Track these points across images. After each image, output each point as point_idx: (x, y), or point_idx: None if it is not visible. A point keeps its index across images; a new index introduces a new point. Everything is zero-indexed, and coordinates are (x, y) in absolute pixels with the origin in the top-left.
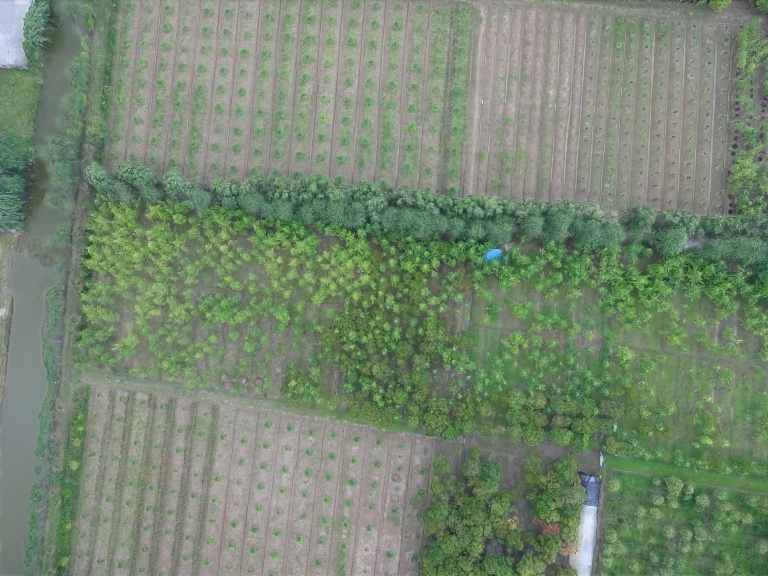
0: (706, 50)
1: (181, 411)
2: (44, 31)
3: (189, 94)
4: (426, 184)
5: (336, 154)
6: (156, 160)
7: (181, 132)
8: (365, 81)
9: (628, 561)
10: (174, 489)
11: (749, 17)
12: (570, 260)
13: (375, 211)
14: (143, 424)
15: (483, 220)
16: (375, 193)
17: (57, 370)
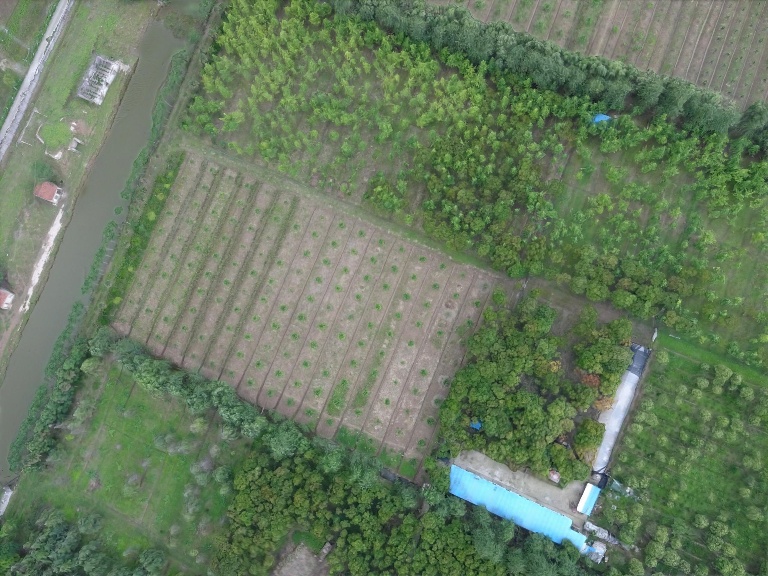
0: None
1: (264, 195)
2: None
3: None
4: None
5: None
6: None
7: None
8: None
9: (656, 438)
10: (237, 263)
11: None
12: (677, 137)
13: (503, 46)
14: (225, 198)
15: (604, 78)
16: (507, 32)
17: (160, 131)
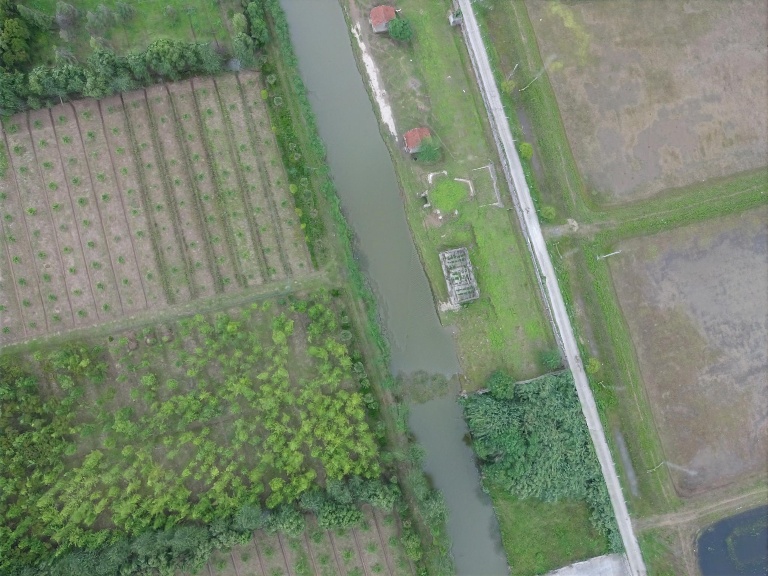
0: None
1: (207, 284)
2: None
3: None
4: None
5: None
6: None
7: (323, 574)
8: None
9: None
10: (183, 206)
11: None
12: None
13: None
14: None
15: None
16: None
17: None
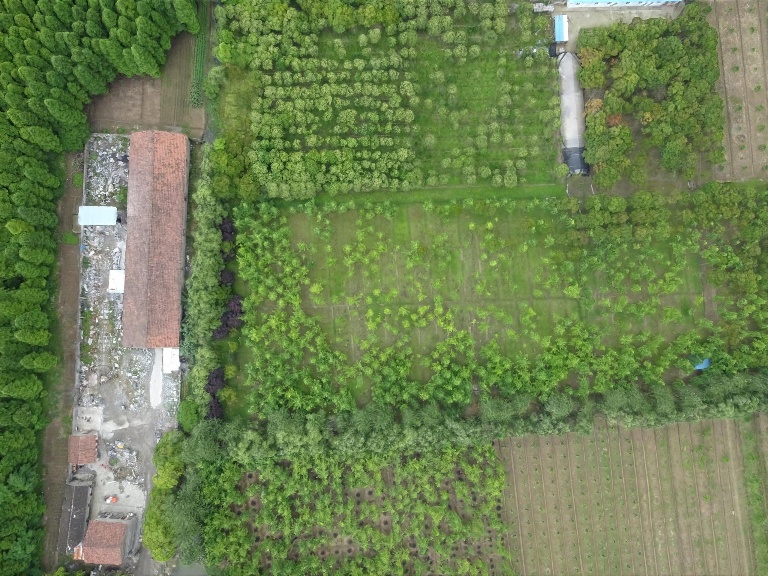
0: None
1: None
2: None
3: None
4: None
5: None
6: None
7: None
8: None
9: None
10: None
11: None
12: (641, 370)
13: None
14: None
15: (733, 394)
16: None
17: None
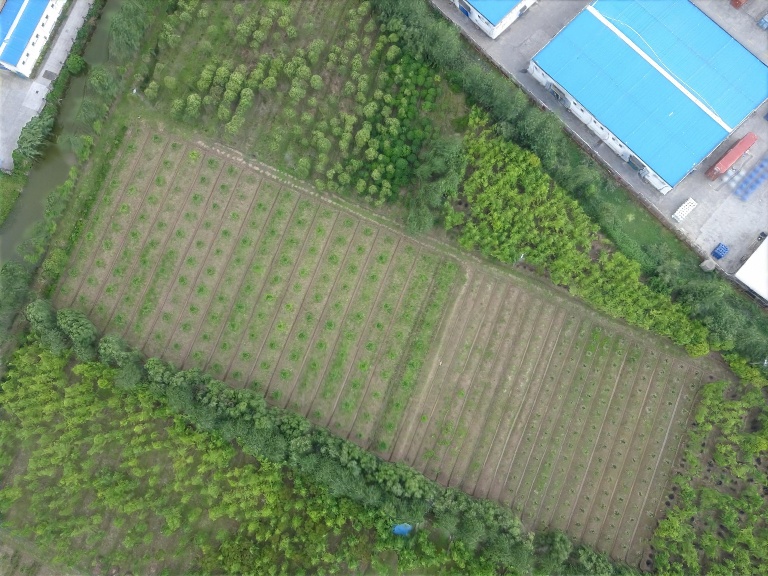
0: (671, 388)
1: None
2: (39, 145)
3: (160, 254)
4: (360, 428)
5: (282, 366)
6: (105, 310)
7: (139, 290)
8: (334, 302)
9: None
10: None
11: (721, 370)
12: (474, 566)
13: (296, 452)
14: None
15: (399, 498)
16: (302, 432)
17: None
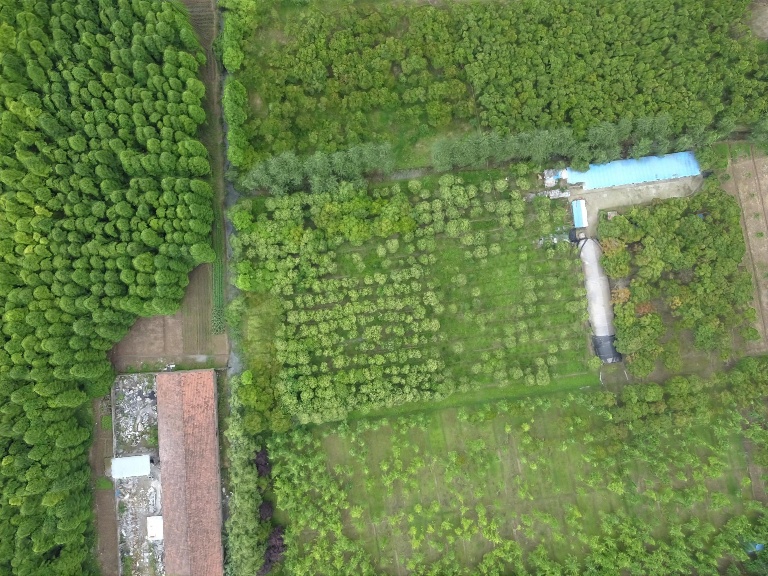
0: None
1: None
2: None
3: None
4: None
5: None
6: None
7: None
8: None
9: None
10: None
11: None
12: (695, 564)
13: None
14: None
15: None
16: None
17: None
